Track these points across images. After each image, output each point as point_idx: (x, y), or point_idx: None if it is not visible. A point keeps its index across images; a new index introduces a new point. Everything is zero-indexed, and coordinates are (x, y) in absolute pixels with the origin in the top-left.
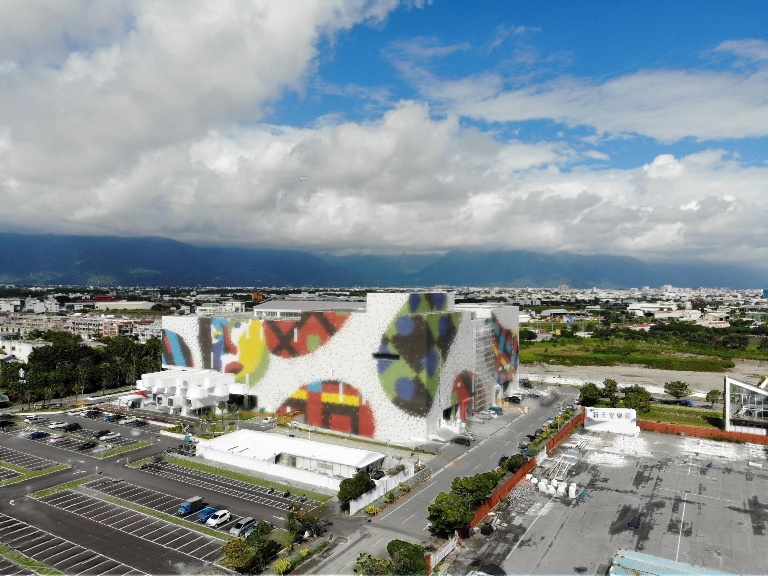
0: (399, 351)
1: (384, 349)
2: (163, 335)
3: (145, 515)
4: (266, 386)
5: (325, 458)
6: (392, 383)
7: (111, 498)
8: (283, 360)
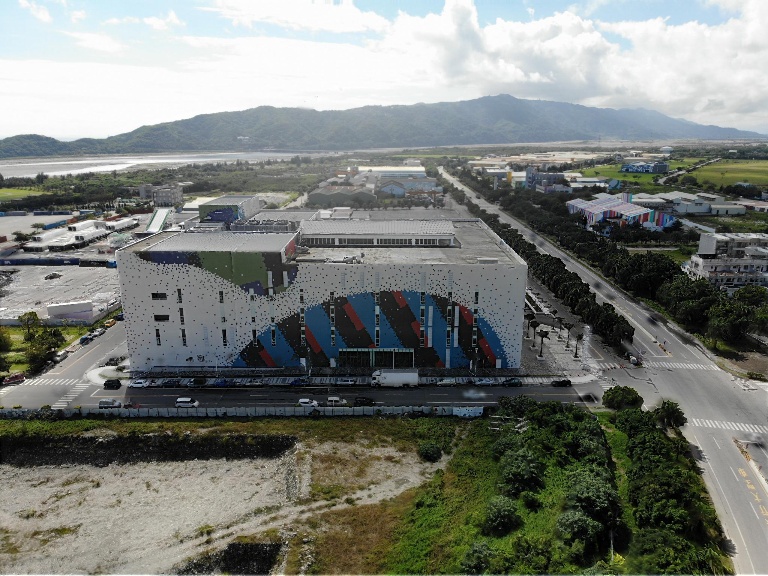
0: None
1: None
2: None
3: None
4: None
5: None
6: None
7: None
8: None
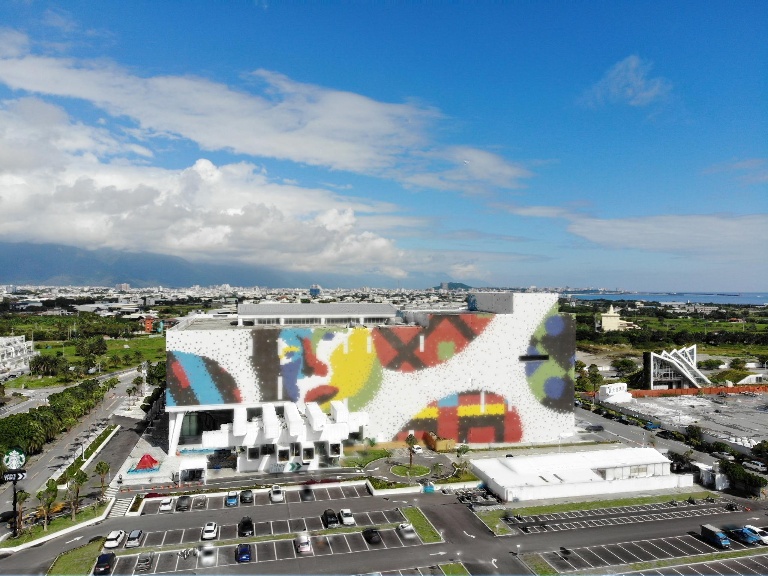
0: (549, 351)
1: (533, 350)
2: (169, 361)
3: (713, 562)
4: (377, 410)
5: (637, 462)
6: (542, 384)
7: (635, 566)
8: (403, 375)
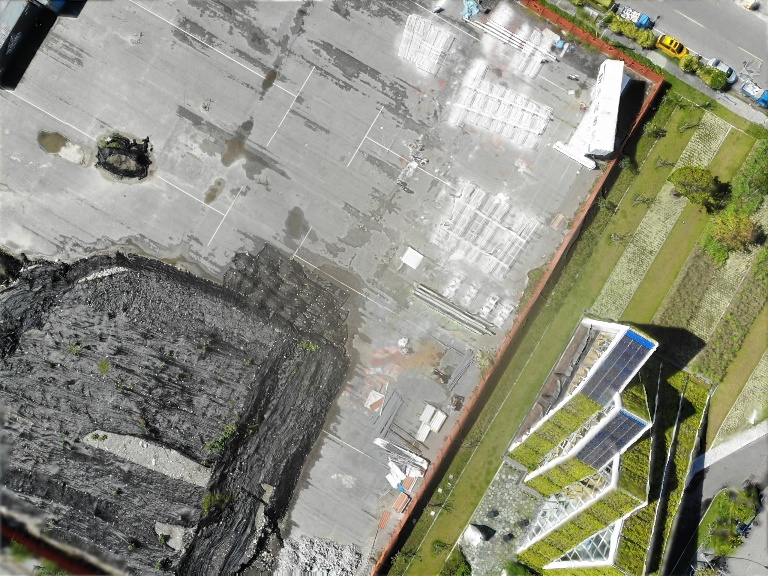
0: None
1: None
2: None
3: None
4: None
5: None
6: None
7: None
8: None
